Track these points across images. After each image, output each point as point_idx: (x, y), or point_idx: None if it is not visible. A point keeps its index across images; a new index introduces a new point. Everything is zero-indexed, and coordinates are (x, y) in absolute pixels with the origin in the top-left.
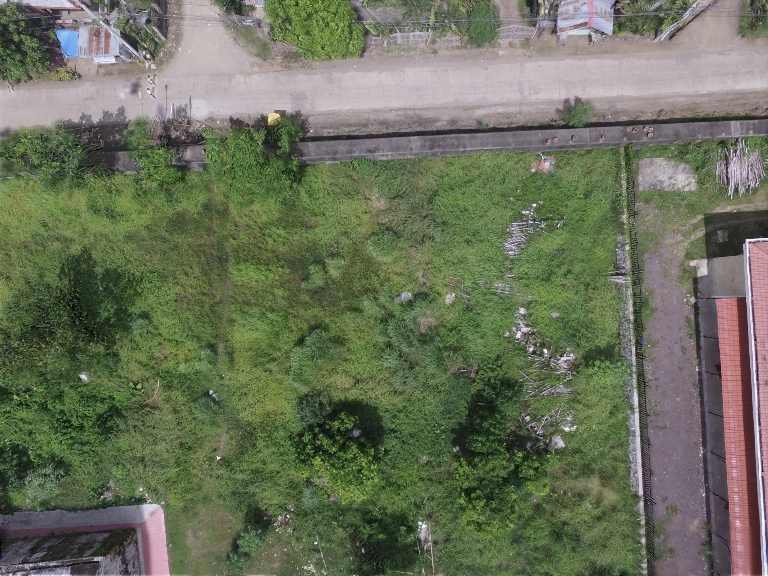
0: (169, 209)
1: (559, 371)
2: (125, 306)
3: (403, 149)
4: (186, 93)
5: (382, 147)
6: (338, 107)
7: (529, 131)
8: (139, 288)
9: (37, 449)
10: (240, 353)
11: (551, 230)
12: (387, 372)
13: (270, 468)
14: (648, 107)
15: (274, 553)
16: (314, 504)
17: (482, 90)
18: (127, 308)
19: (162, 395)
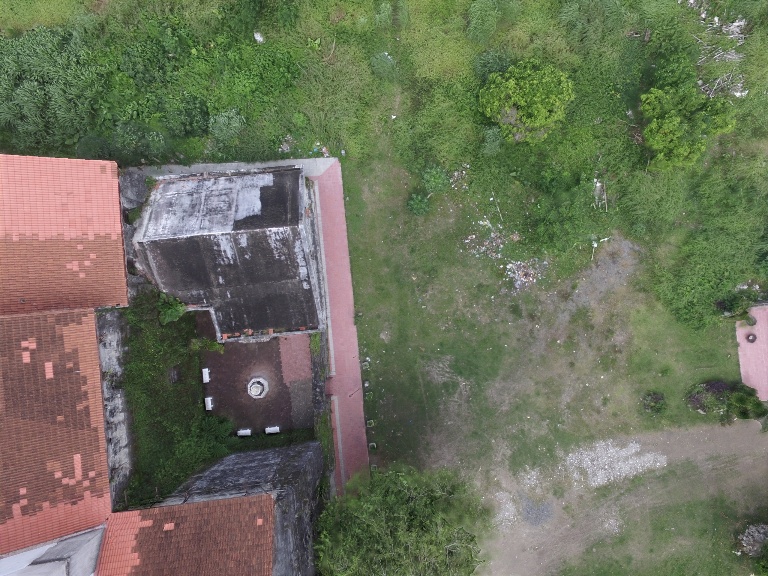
0: None
1: (732, 35)
2: None
3: None
4: None
5: None
6: None
7: None
8: None
9: (215, 102)
10: (415, 15)
11: None
12: (564, 30)
13: (448, 123)
14: None
15: (450, 208)
16: None
17: None
18: None
19: (341, 49)
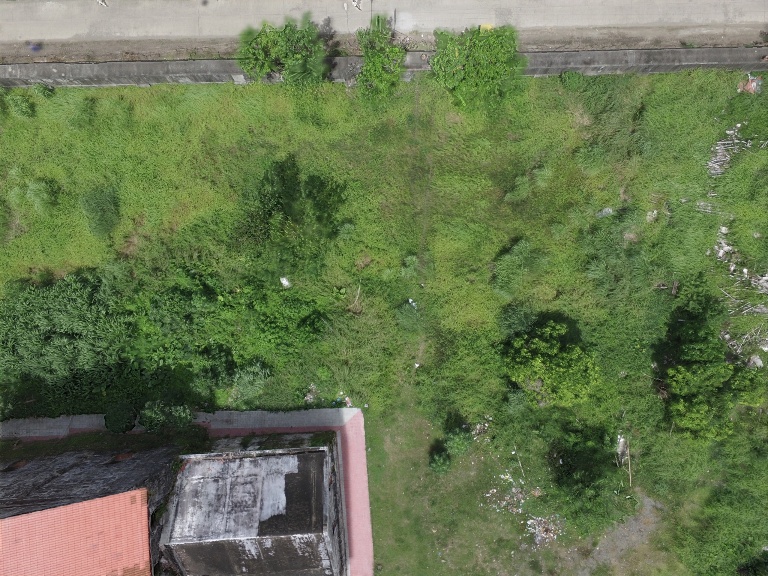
0: (374, 118)
1: (761, 290)
2: (328, 213)
3: (618, 62)
4: (391, 6)
5: (597, 59)
6: (542, 24)
7: None
8: (344, 195)
9: (240, 349)
10: (441, 263)
11: (756, 150)
12: (590, 285)
13: (471, 376)
14: None
15: (471, 461)
16: None
17: (687, 11)
18: (331, 214)
19: (366, 300)
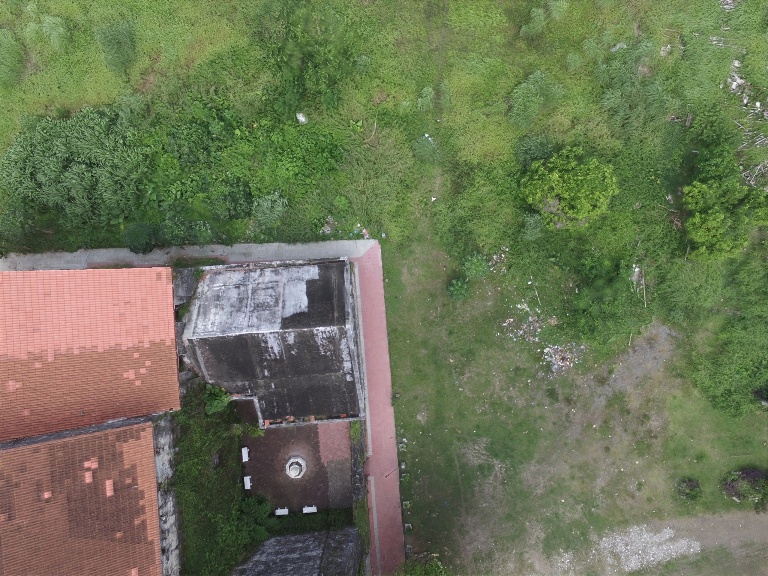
0: None
1: None
2: (344, 49)
3: None
4: None
5: None
6: None
7: None
8: (359, 30)
9: (258, 182)
10: (457, 98)
11: None
12: (605, 115)
13: (487, 207)
14: None
15: (488, 291)
16: (534, 238)
17: None
18: (347, 50)
19: (383, 132)
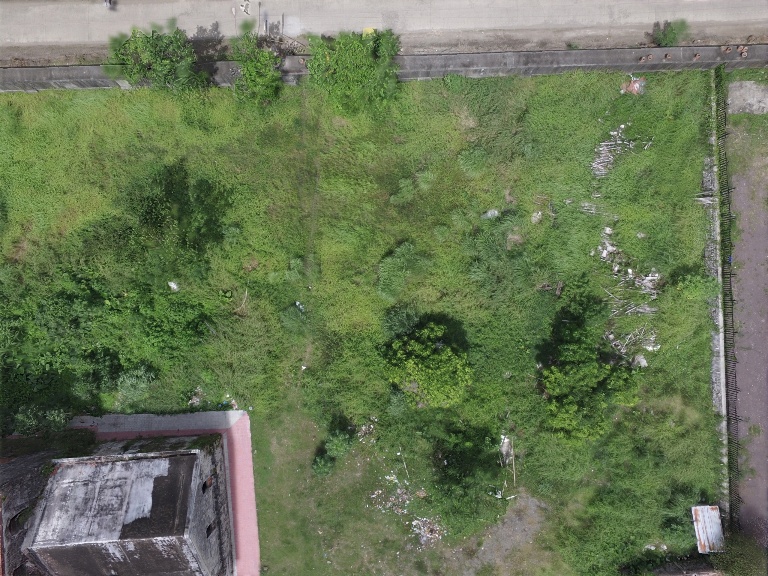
0: (261, 122)
1: (644, 290)
2: (215, 216)
3: (497, 64)
4: (279, 10)
5: (476, 62)
6: (428, 27)
7: (623, 49)
8: (230, 199)
9: (127, 353)
10: (327, 265)
11: (639, 151)
12: (474, 286)
13: (356, 378)
14: (737, 33)
15: (357, 462)
16: (400, 413)
17: (572, 13)
18: (218, 218)
19: (251, 303)
